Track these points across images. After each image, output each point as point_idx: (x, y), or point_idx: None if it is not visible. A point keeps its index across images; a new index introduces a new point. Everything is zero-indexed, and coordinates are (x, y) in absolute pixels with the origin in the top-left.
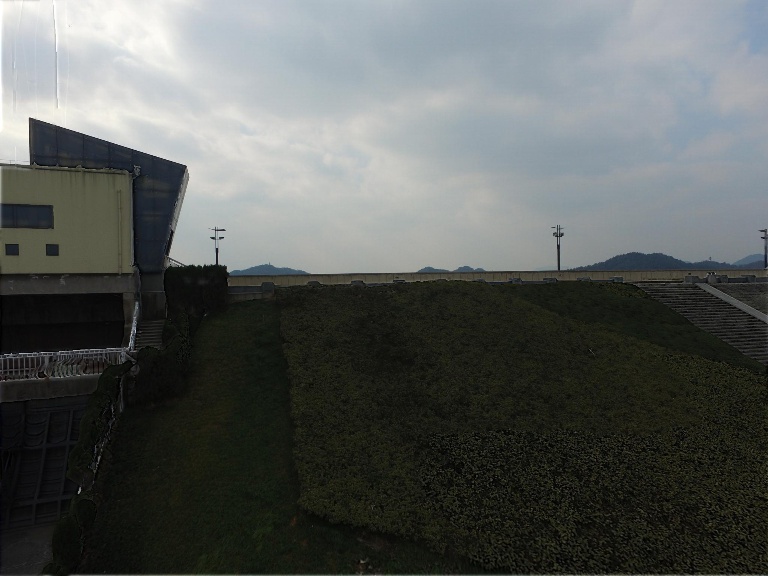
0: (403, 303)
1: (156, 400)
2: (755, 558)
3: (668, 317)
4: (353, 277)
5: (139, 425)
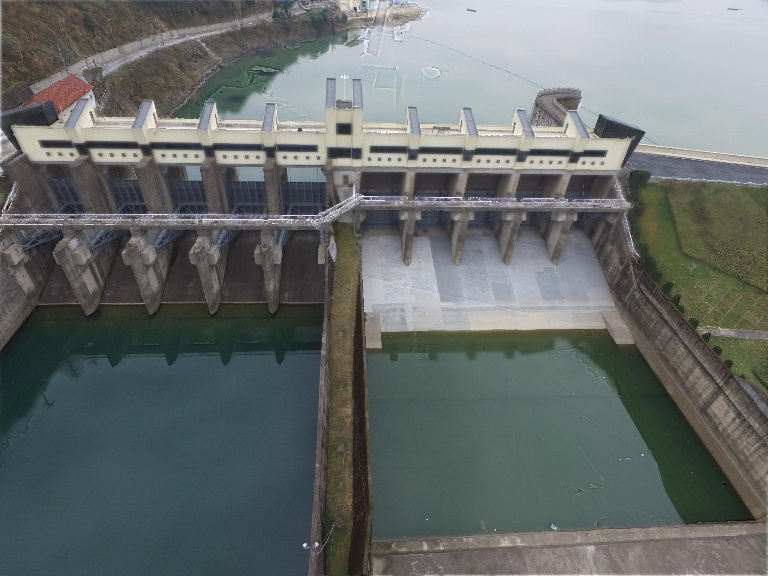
0: (706, 195)
1: None
2: (767, 278)
3: None
4: (671, 150)
5: None
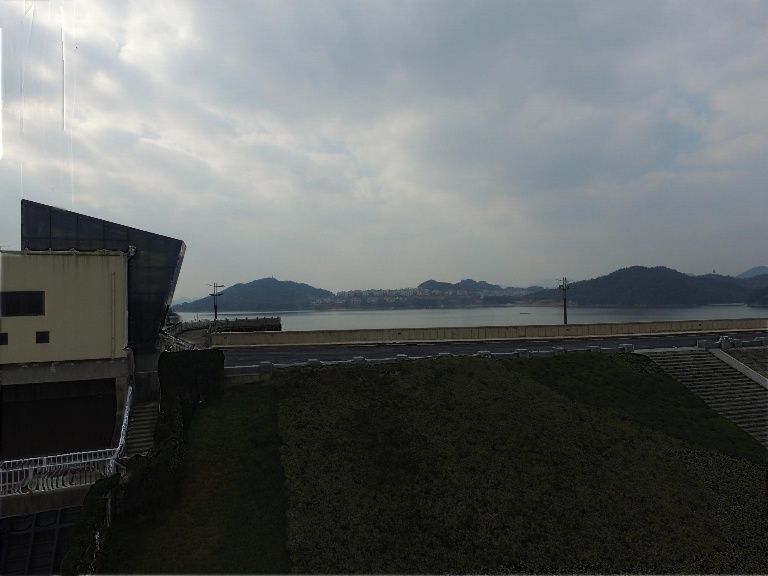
0: (406, 389)
1: (146, 512)
2: None
3: (683, 398)
4: (355, 333)
5: (126, 546)
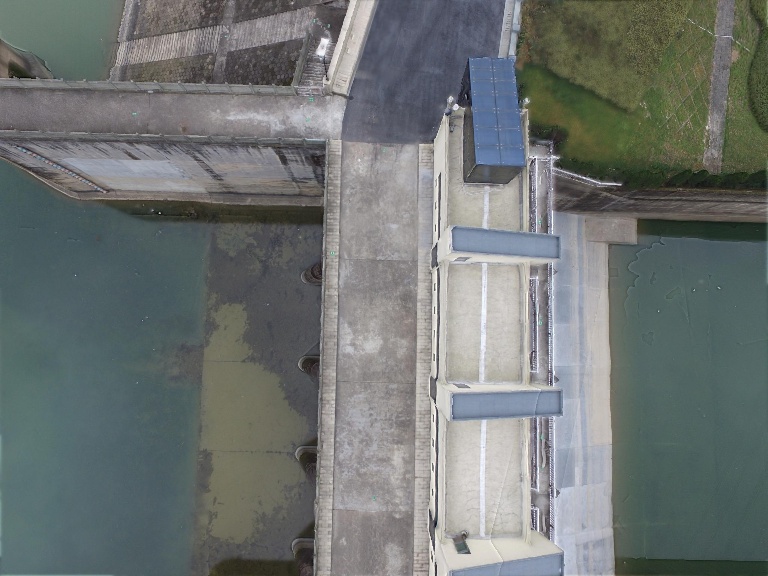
0: None
1: None
2: None
3: None
4: None
5: None
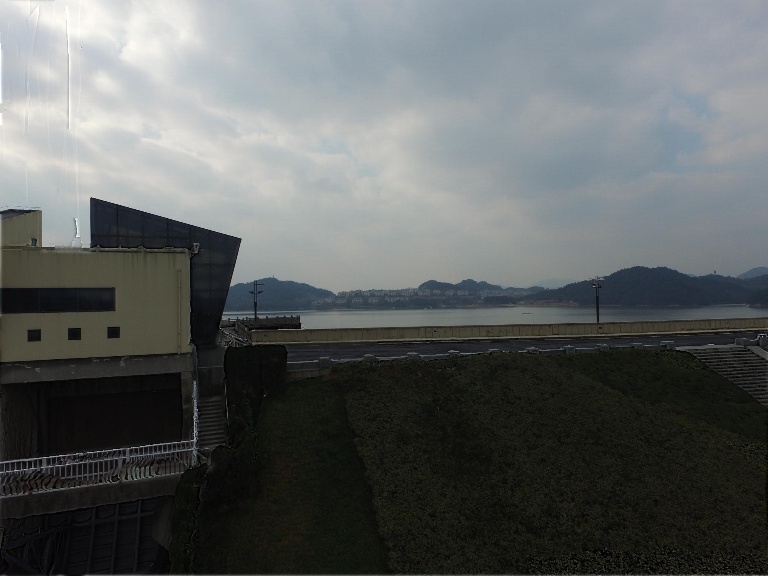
0: (465, 383)
1: (229, 502)
2: None
3: (732, 394)
4: (392, 331)
5: (216, 533)
